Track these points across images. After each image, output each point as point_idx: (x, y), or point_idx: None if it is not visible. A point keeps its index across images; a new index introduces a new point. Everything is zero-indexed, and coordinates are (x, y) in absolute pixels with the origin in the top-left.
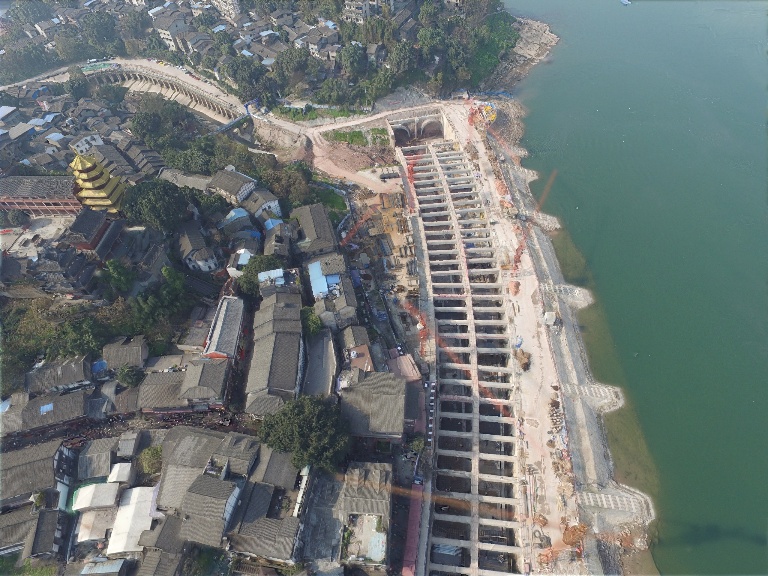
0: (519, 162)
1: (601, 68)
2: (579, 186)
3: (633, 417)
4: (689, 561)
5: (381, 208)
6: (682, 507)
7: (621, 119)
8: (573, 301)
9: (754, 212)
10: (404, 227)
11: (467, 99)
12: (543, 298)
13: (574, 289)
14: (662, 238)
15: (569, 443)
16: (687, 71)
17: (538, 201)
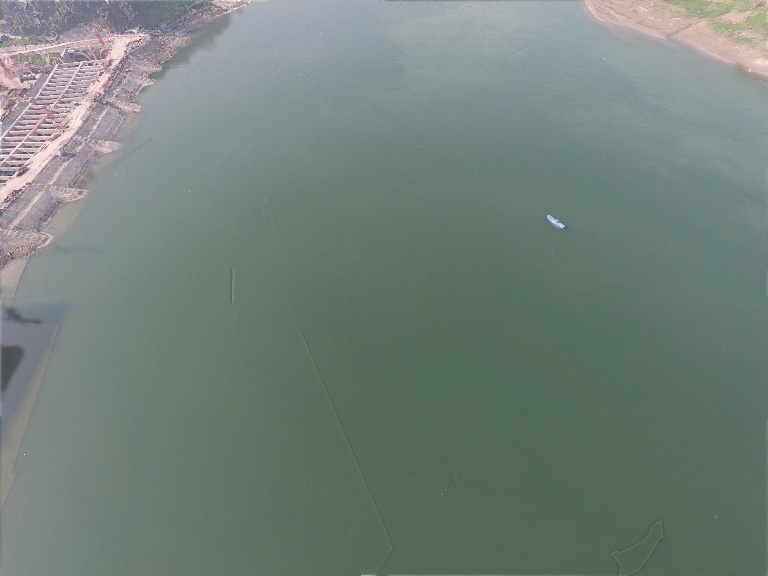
0: (148, 74)
1: (271, 15)
2: (173, 87)
3: (83, 204)
4: (48, 262)
5: (3, 97)
6: (68, 240)
7: (250, 47)
8: (100, 148)
9: (280, 100)
10: (9, 106)
11: (137, 33)
12: (69, 143)
13: (106, 142)
14: (200, 115)
15: (9, 207)
16: (336, 17)
17: (140, 97)
